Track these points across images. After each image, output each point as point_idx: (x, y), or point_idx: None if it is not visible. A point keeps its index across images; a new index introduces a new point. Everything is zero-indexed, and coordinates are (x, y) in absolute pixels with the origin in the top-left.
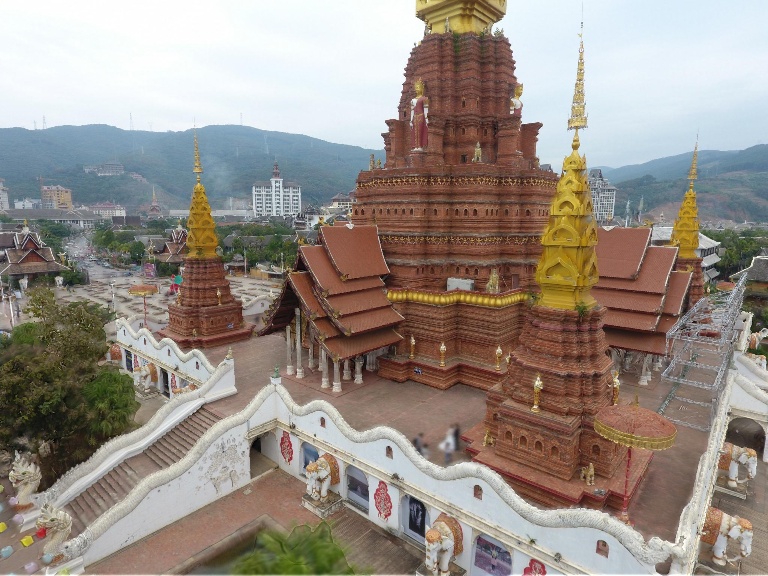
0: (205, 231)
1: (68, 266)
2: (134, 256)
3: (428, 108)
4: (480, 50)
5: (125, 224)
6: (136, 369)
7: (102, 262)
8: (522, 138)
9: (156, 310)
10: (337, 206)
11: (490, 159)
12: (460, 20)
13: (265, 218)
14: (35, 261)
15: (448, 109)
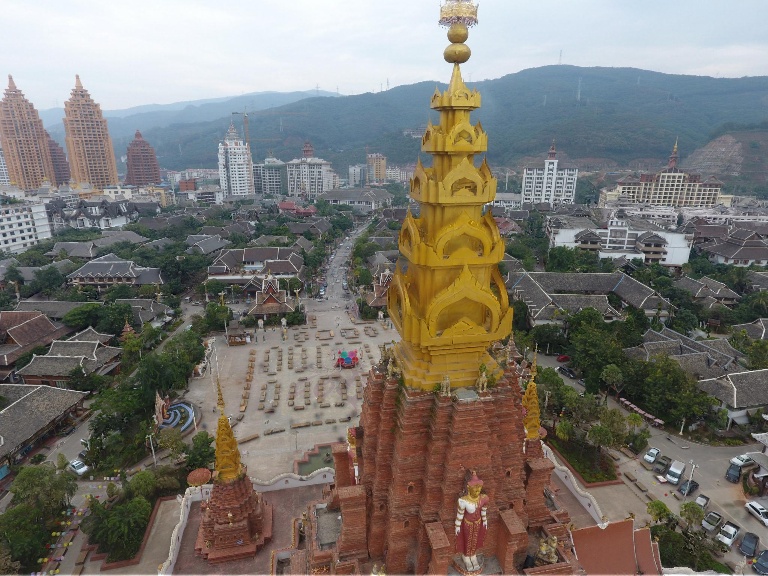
0: (223, 459)
1: (293, 308)
2: (361, 282)
3: (358, 465)
4: (428, 413)
5: (393, 217)
6: (158, 568)
7: (347, 275)
8: (498, 531)
9: (304, 399)
10: (621, 191)
11: (416, 567)
12: (418, 354)
13: (528, 207)
14: (273, 302)
15: (377, 479)
